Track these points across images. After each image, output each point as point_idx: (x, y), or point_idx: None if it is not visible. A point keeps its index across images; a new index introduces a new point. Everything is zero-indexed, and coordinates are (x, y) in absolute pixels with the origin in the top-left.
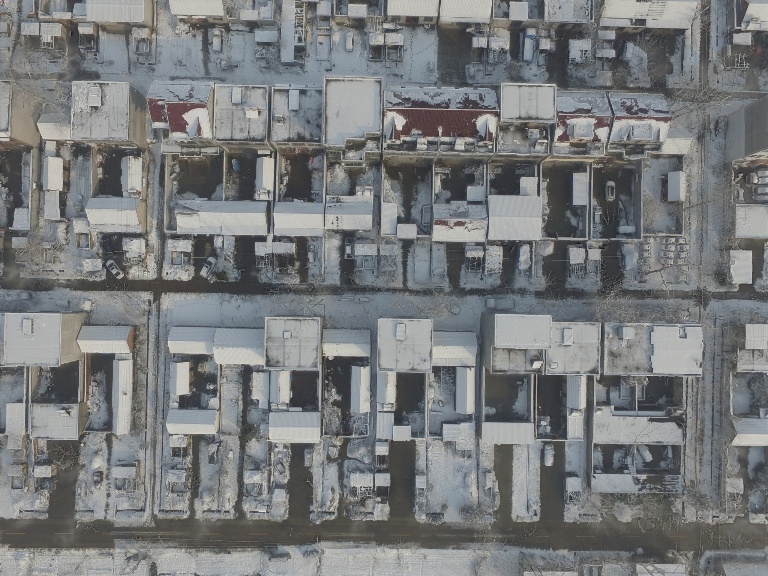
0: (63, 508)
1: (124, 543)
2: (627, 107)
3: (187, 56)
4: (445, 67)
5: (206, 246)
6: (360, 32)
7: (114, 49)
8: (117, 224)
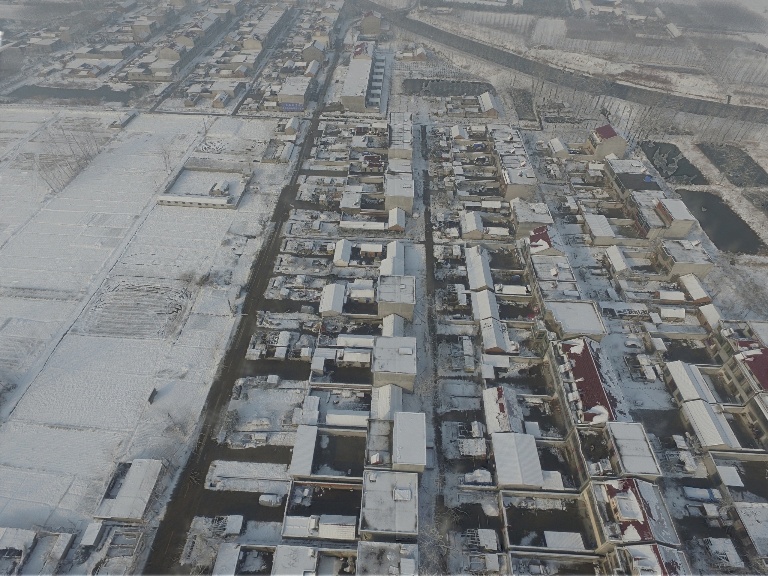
0: (300, 205)
1: (273, 225)
2: (674, 567)
3: (582, 259)
4: (644, 416)
5: (457, 264)
6: (644, 353)
7: (573, 229)
8: (466, 224)
